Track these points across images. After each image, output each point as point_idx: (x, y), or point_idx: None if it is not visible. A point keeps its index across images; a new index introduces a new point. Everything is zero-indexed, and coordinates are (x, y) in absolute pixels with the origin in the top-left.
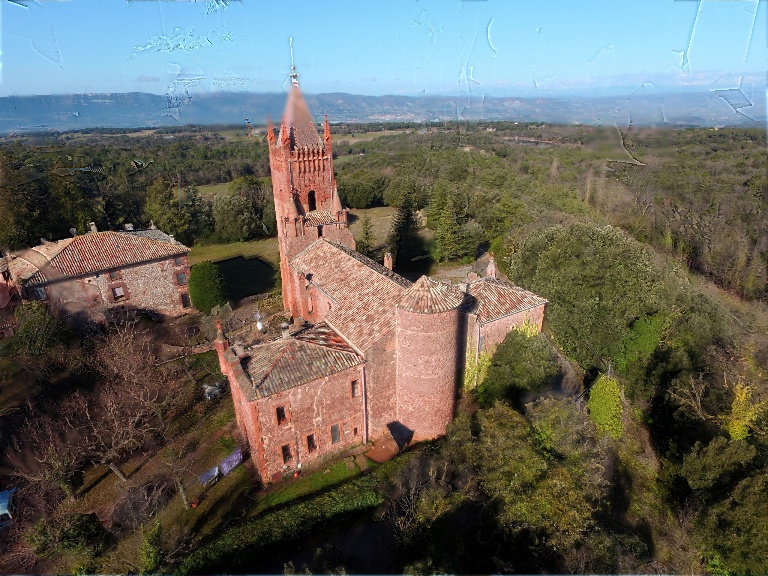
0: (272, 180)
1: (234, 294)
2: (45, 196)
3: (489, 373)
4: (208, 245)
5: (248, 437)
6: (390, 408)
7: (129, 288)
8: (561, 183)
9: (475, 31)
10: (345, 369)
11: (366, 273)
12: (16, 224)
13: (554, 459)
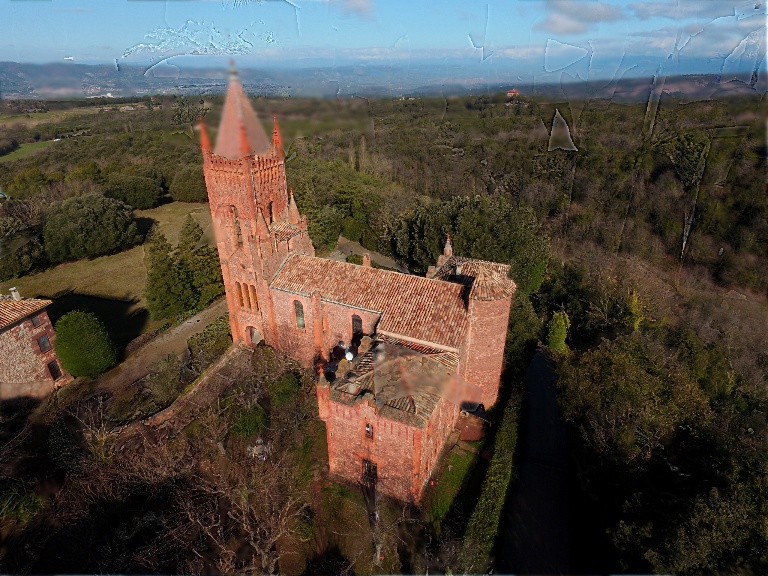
0: (209, 195)
1: None
2: None
3: (508, 335)
4: None
5: (378, 470)
6: None
7: None
8: (387, 161)
9: (301, 14)
10: None
11: (389, 277)
12: None
13: None
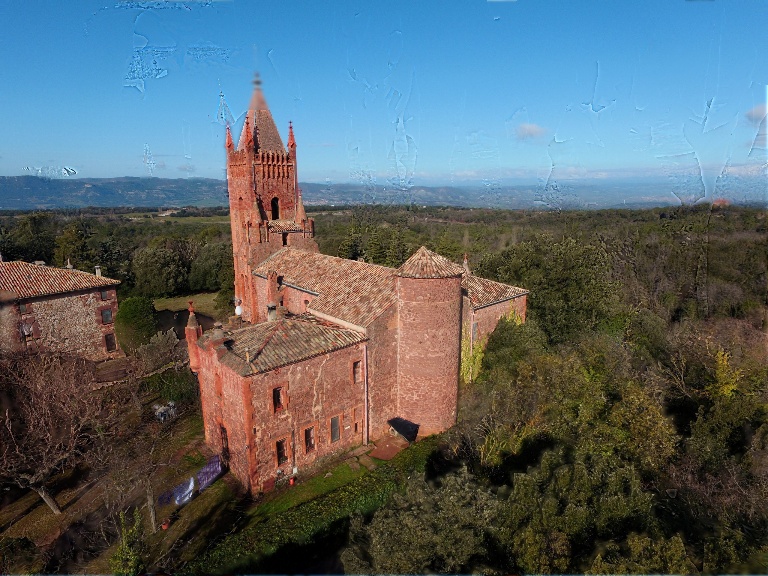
0: None
1: None
2: None
3: (488, 359)
4: None
5: (228, 441)
6: (391, 401)
7: (41, 325)
8: (493, 227)
9: (409, 87)
10: (347, 346)
11: (348, 265)
12: None
13: (605, 397)
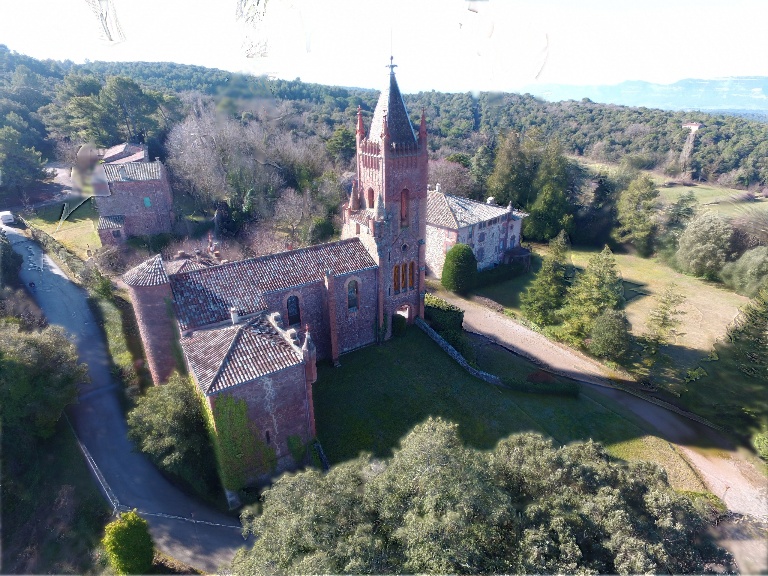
0: None
1: (509, 295)
2: (534, 166)
3: None
4: (662, 264)
5: None
6: None
7: None
8: None
9: None
10: None
11: None
12: (499, 181)
13: None
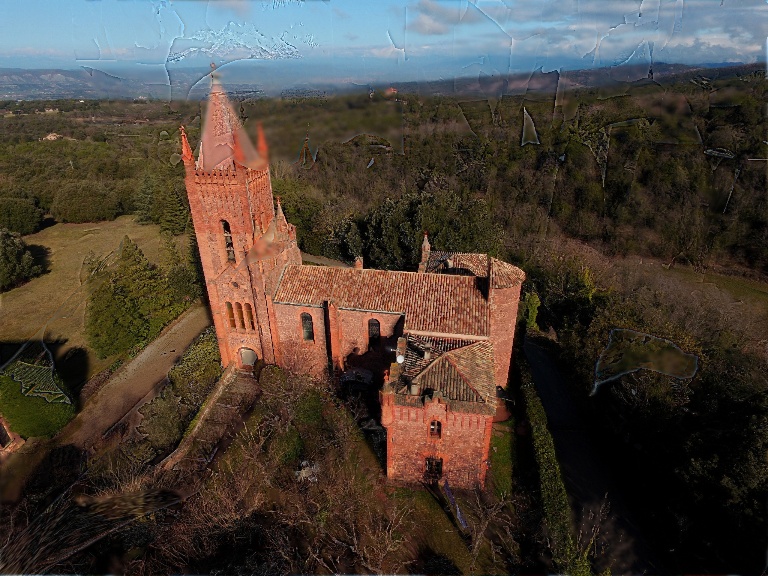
0: (192, 211)
1: None
2: None
3: None
4: None
5: (444, 465)
6: None
7: None
8: None
9: None
10: None
11: (400, 277)
12: None
13: None
